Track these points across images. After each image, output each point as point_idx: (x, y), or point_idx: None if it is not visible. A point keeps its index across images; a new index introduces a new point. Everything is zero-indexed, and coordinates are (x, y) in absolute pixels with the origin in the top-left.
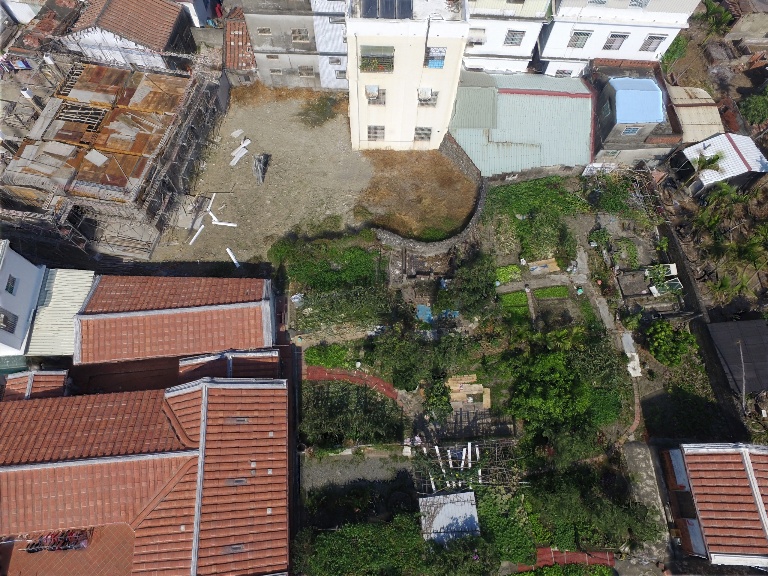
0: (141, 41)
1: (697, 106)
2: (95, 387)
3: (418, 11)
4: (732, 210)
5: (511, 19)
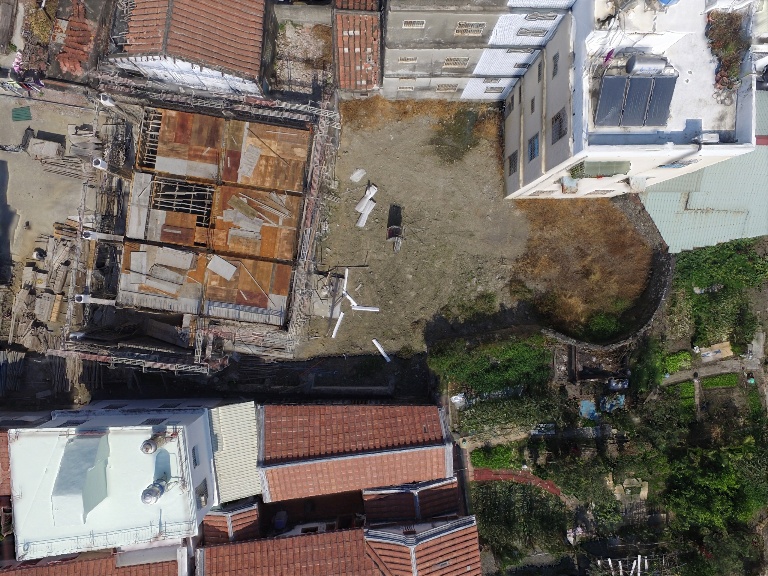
0: (228, 67)
1: None
2: None
3: (674, 104)
4: None
5: (767, 43)
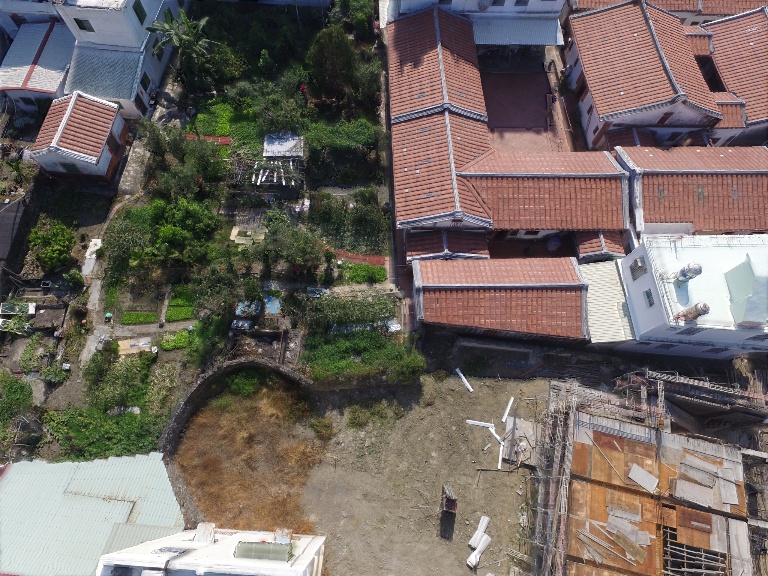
0: None
1: None
2: None
3: None
4: None
5: None
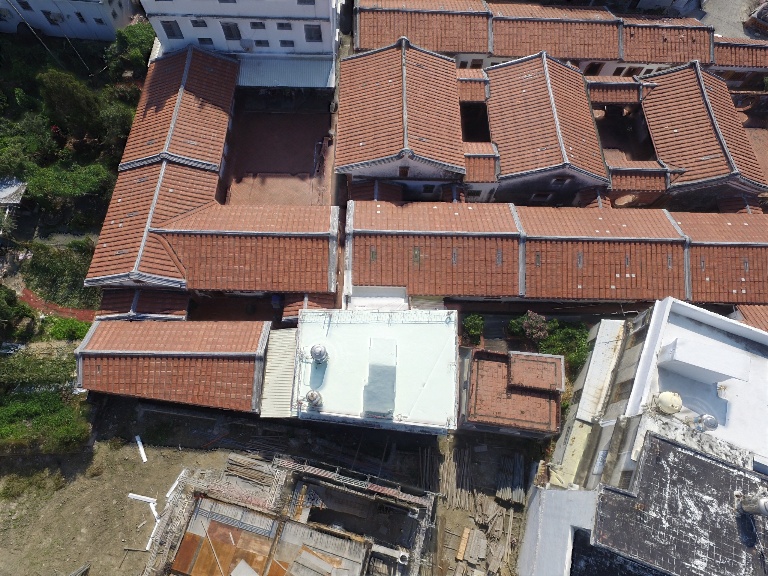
0: None
1: None
2: (279, 322)
3: None
4: None
5: None
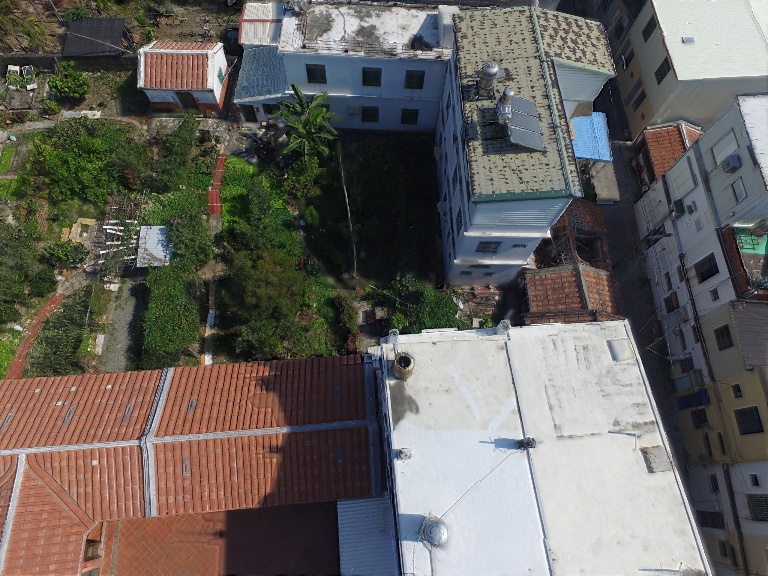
0: None
1: None
2: None
3: None
4: None
5: None
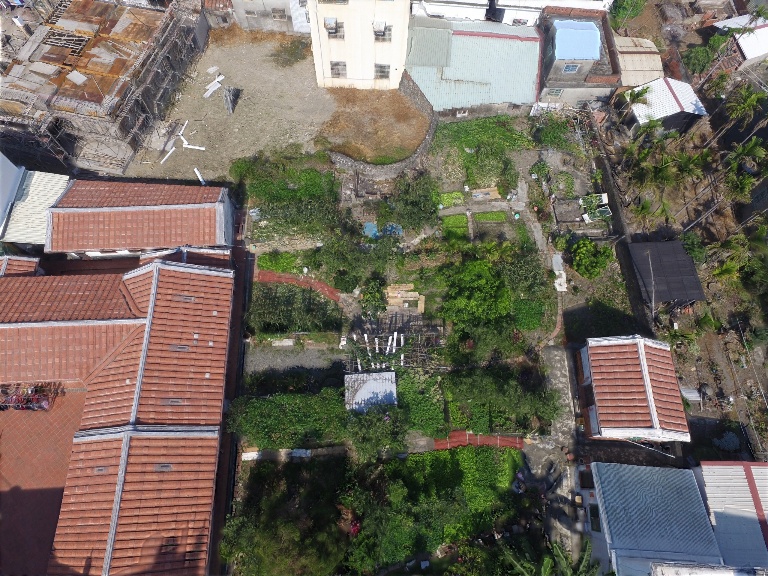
0: None
1: (641, 54)
2: None
3: None
4: (663, 146)
5: None
